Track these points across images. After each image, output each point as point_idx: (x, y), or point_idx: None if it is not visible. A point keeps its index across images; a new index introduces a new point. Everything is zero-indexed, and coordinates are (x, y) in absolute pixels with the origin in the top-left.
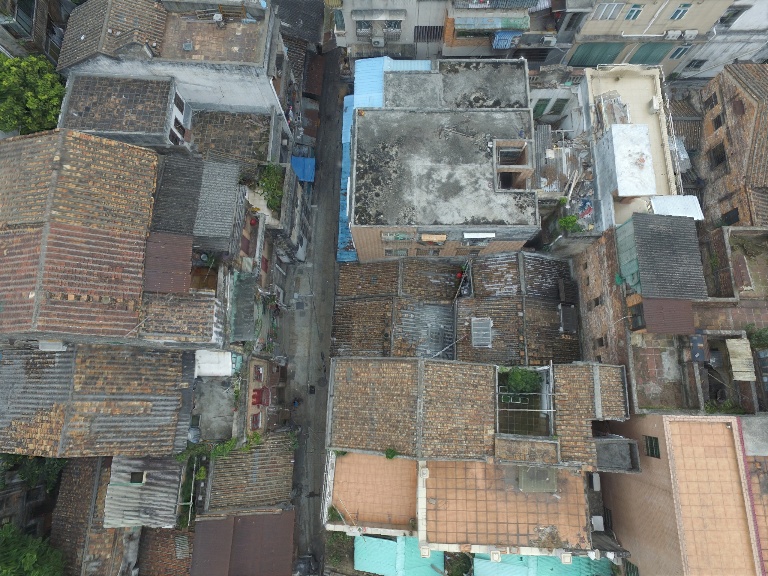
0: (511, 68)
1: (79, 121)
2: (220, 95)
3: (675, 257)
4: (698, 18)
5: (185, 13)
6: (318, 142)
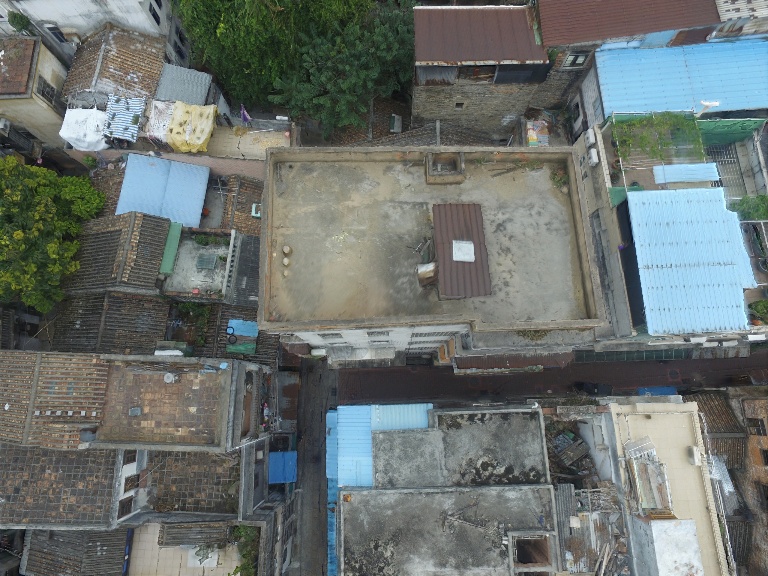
0: (523, 419)
1: (6, 508)
2: None
3: None
4: (739, 336)
5: (131, 362)
6: (300, 405)
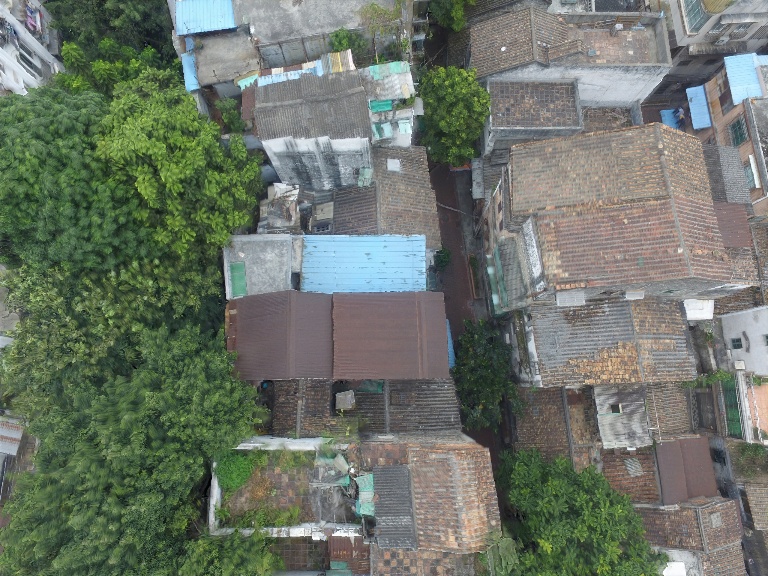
0: None
1: (504, 120)
2: (601, 93)
3: None
4: None
5: (581, 24)
6: None
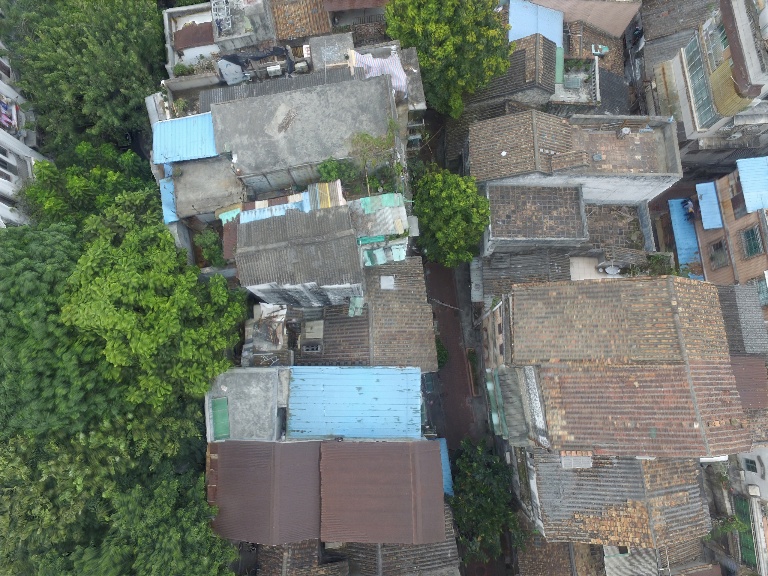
0: None
1: (504, 229)
2: (606, 194)
3: None
4: None
5: (586, 125)
6: None
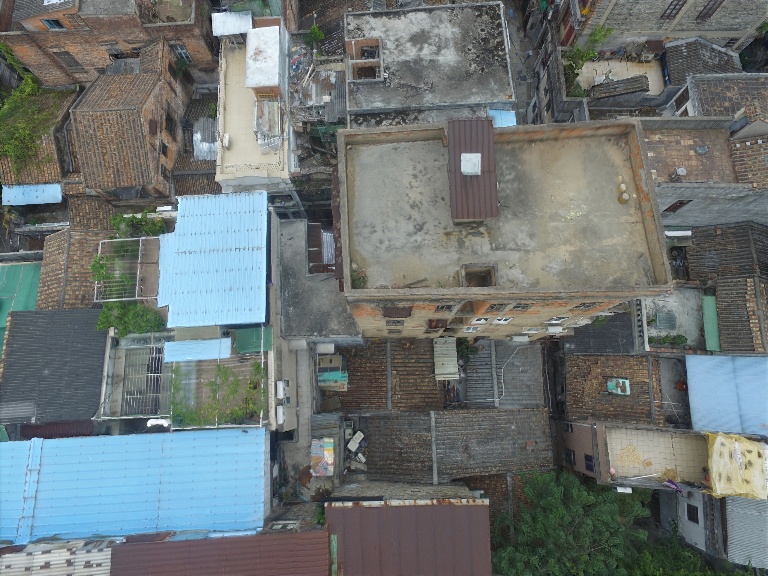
0: None
1: None
2: None
3: None
4: None
5: None
6: None
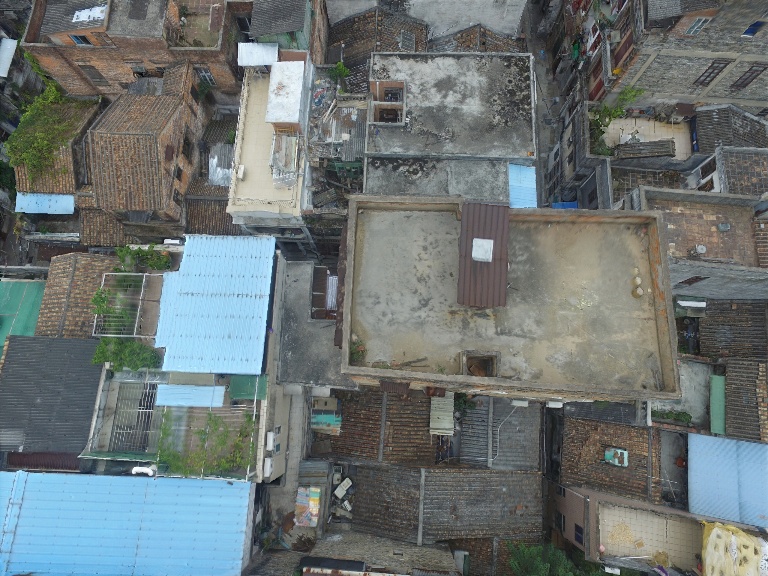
0: None
1: None
2: None
3: (275, 5)
4: None
5: None
6: None
